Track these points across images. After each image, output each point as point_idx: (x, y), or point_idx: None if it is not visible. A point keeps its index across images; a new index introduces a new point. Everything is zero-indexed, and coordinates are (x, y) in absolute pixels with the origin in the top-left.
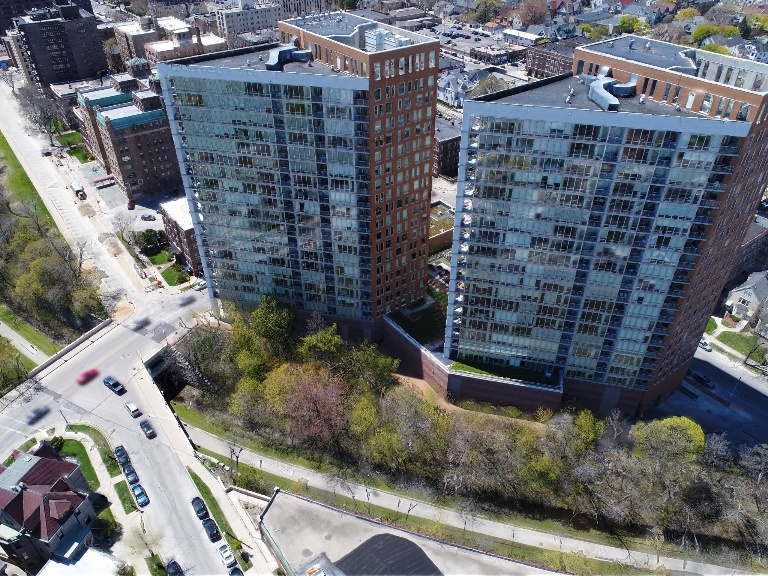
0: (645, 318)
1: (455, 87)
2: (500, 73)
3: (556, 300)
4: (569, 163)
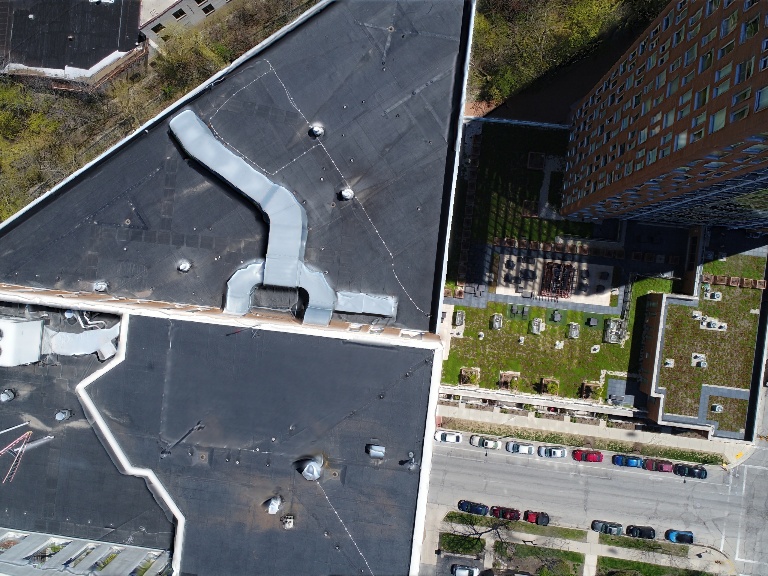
0: None
1: None
2: None
3: None
4: None
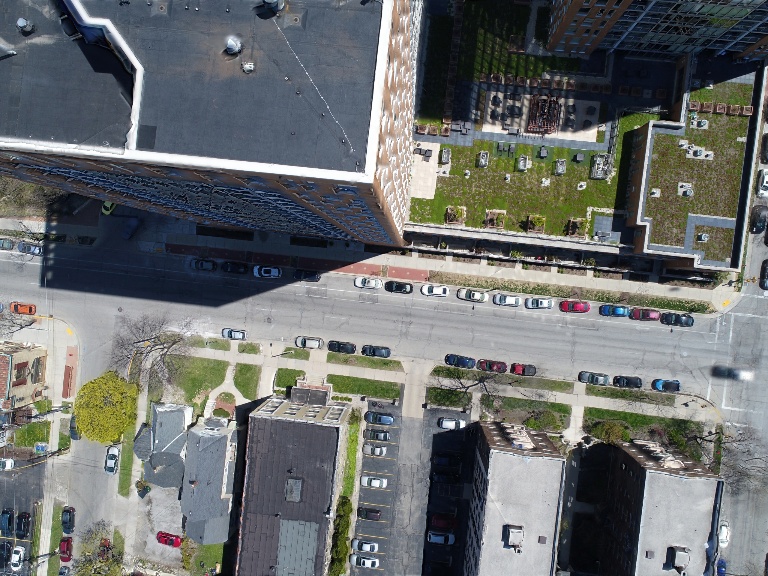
0: None
1: None
2: None
3: None
4: None
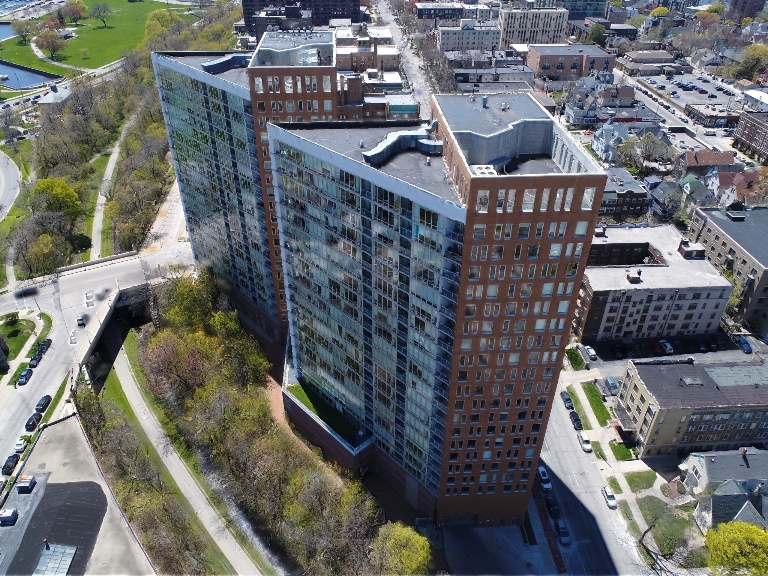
0: (421, 409)
1: (608, 139)
2: (689, 135)
3: (355, 354)
4: (340, 208)
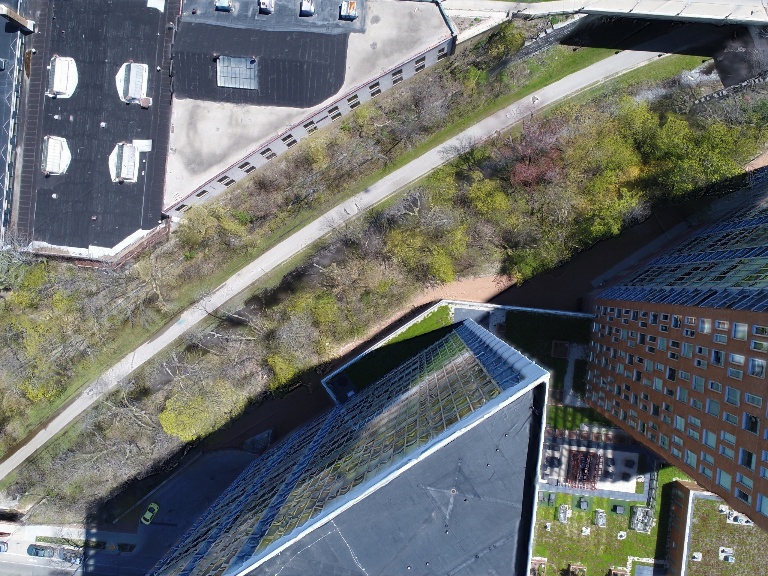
0: None
1: None
2: None
3: None
4: None
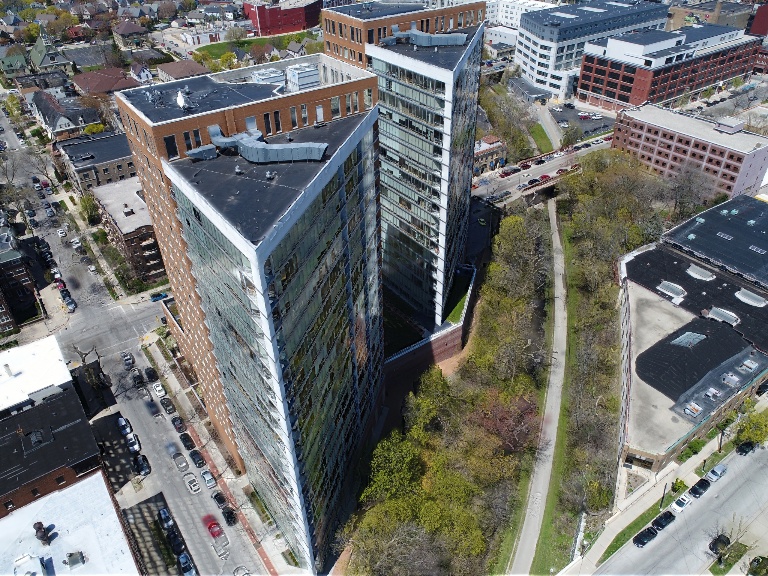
0: None
1: None
2: None
3: None
4: None
